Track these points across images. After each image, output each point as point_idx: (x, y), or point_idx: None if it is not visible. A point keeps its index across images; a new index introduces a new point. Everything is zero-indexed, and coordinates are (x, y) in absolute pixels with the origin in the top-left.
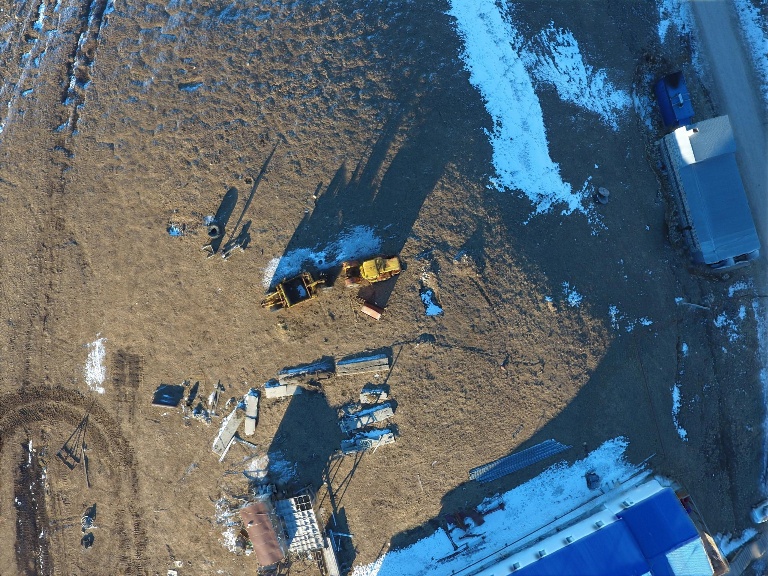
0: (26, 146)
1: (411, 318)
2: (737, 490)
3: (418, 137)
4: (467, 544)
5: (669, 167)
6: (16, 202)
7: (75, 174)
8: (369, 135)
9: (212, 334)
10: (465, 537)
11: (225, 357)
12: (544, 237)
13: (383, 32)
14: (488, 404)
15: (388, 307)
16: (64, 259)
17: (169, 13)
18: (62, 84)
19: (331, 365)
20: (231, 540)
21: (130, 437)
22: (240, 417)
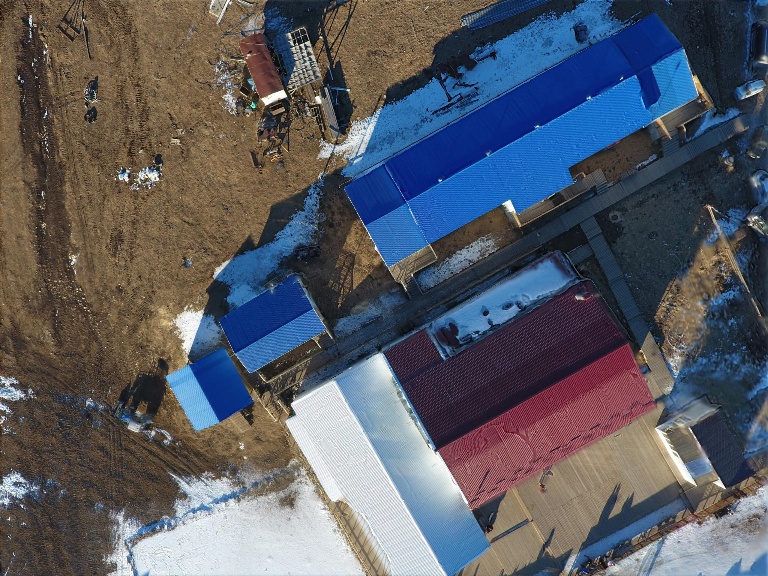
0: None
1: None
2: (721, 69)
3: None
4: (461, 94)
5: None
6: None
7: None
8: None
9: None
10: (458, 86)
11: None
12: None
13: None
14: None
15: None
16: None
17: None
18: None
19: None
20: (231, 103)
21: (128, 5)
22: None
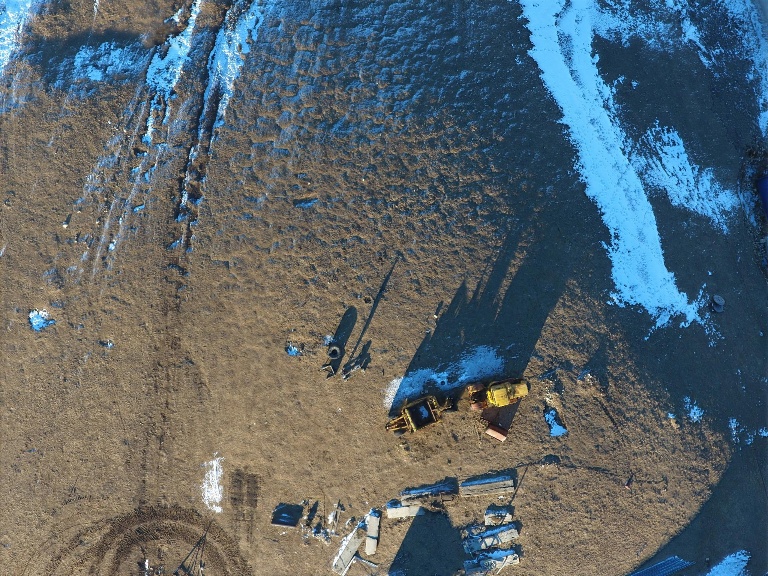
0: (139, 264)
1: (536, 439)
2: None
3: (538, 254)
4: None
5: None
6: (130, 321)
7: (190, 293)
8: (489, 252)
9: (332, 454)
10: None
11: (345, 477)
12: (665, 352)
13: (498, 144)
14: (613, 524)
15: (512, 428)
16: (180, 378)
17: (281, 126)
18: (174, 200)
19: (455, 486)
20: None
21: (248, 556)
22: (361, 537)
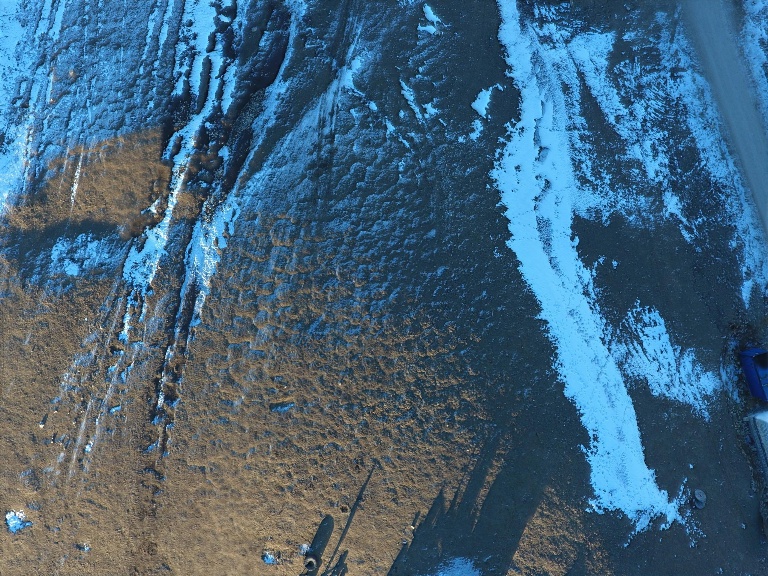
0: (116, 467)
1: None
2: None
3: (516, 462)
4: None
5: (759, 445)
6: (107, 525)
7: (167, 498)
8: (466, 461)
9: None
10: None
11: None
12: (645, 558)
13: (476, 346)
14: None
15: None
16: None
17: (257, 327)
18: (150, 402)
19: None
20: None
21: None
22: None
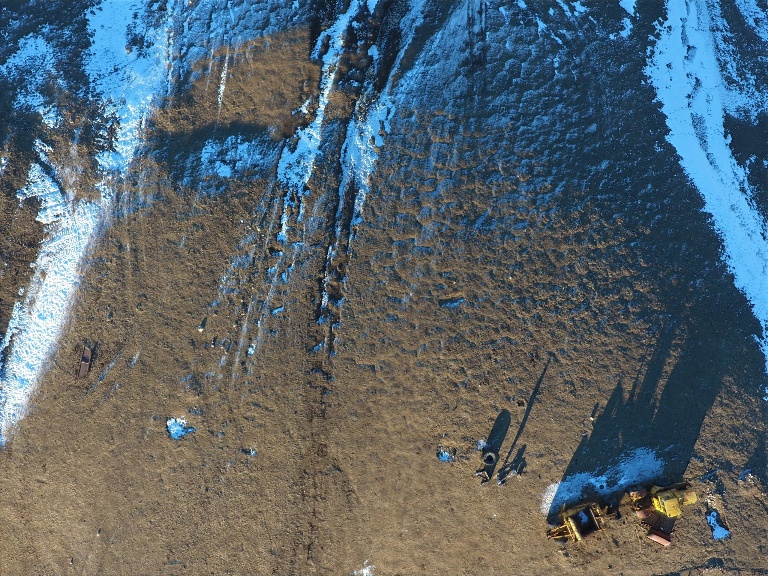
0: (281, 369)
1: (699, 543)
2: None
3: (693, 351)
4: None
5: None
6: (274, 428)
7: (336, 398)
8: (643, 351)
9: (487, 561)
10: None
11: None
12: None
13: (645, 237)
14: None
15: (674, 532)
16: (328, 486)
17: (421, 223)
18: (314, 302)
19: None
20: None
21: None
22: None
